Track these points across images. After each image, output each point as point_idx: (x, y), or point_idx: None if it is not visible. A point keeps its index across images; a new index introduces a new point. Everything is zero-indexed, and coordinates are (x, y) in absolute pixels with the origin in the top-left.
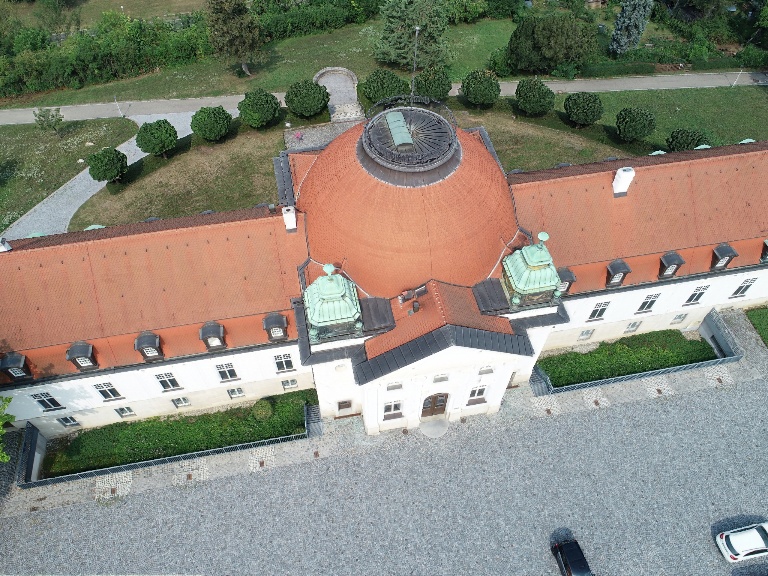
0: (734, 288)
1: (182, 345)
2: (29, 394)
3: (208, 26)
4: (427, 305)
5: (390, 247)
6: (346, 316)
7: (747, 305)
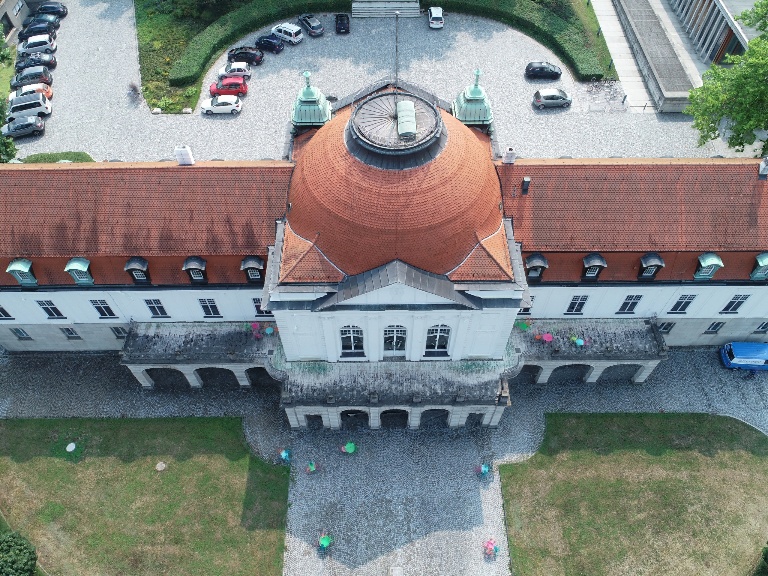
0: None
1: None
2: None
3: None
4: None
5: None
6: None
7: None
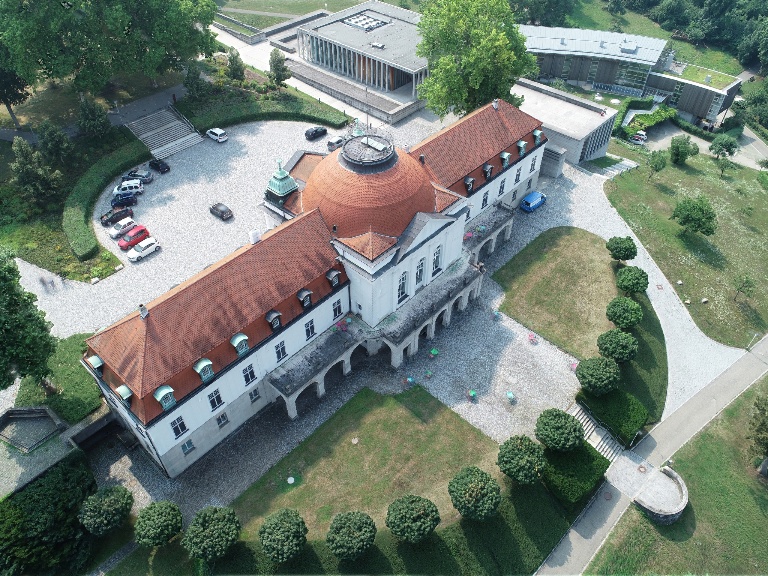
0: None
1: None
2: None
3: None
4: (320, 160)
5: None
6: None
7: None
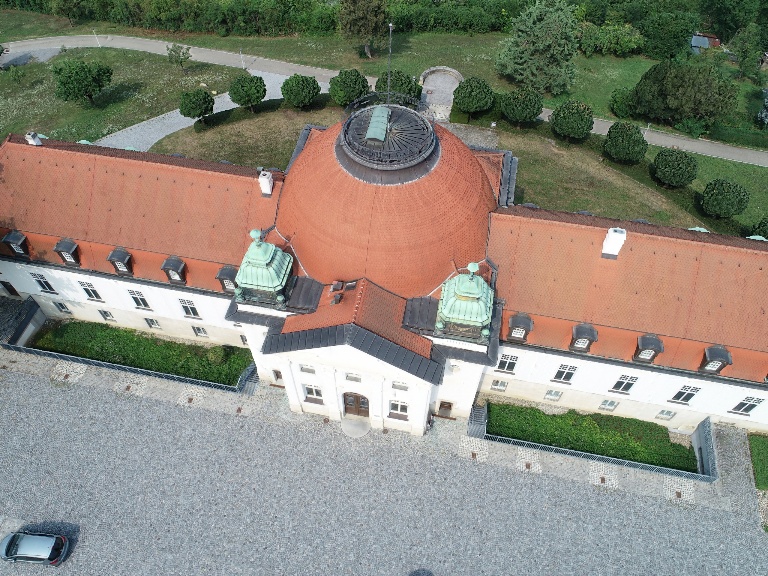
0: (734, 402)
1: (150, 270)
2: (28, 271)
3: (341, 3)
4: (348, 300)
5: (331, 234)
6: (267, 285)
7: (754, 428)
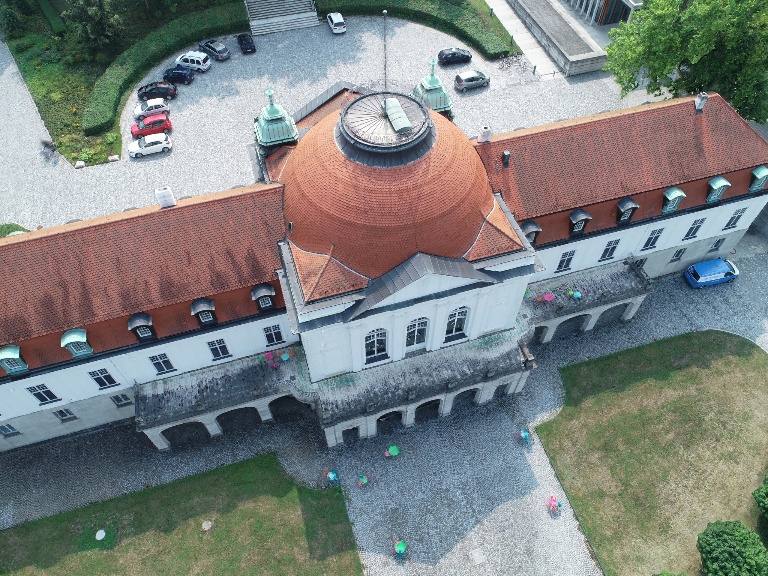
0: None
1: None
2: None
3: None
4: None
5: None
6: None
7: None
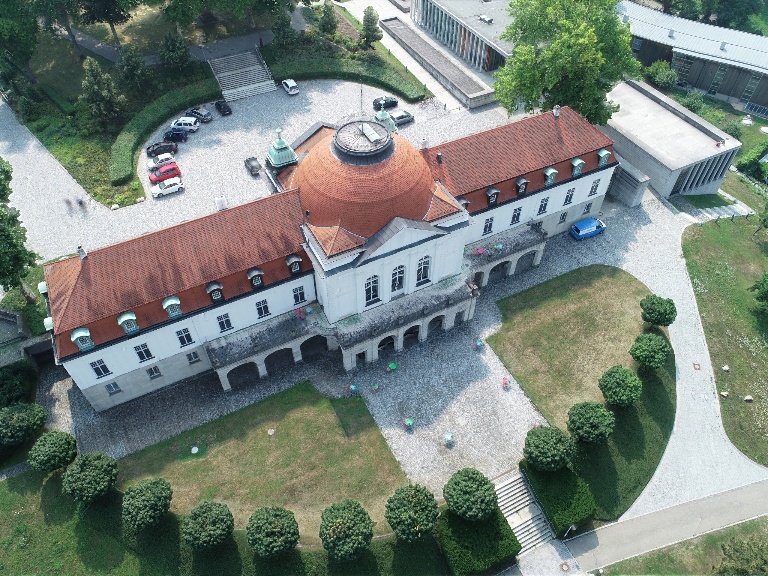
0: None
1: None
2: None
3: None
4: None
5: None
6: None
7: None
